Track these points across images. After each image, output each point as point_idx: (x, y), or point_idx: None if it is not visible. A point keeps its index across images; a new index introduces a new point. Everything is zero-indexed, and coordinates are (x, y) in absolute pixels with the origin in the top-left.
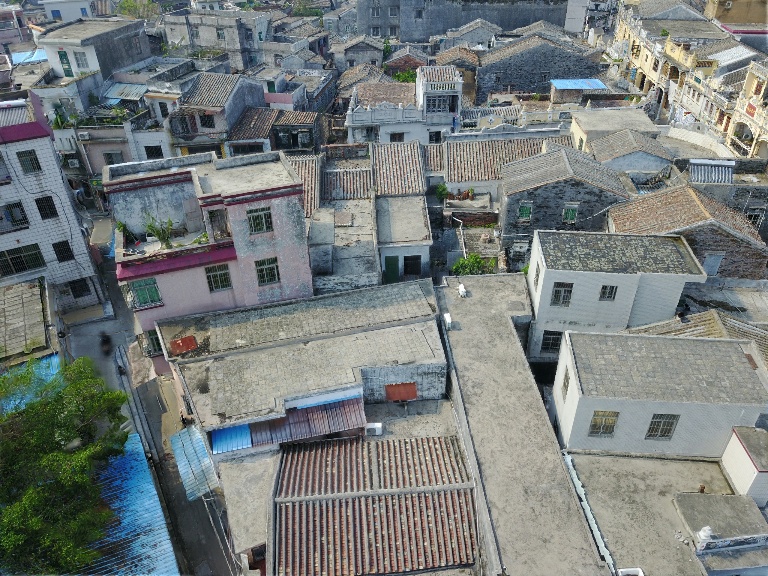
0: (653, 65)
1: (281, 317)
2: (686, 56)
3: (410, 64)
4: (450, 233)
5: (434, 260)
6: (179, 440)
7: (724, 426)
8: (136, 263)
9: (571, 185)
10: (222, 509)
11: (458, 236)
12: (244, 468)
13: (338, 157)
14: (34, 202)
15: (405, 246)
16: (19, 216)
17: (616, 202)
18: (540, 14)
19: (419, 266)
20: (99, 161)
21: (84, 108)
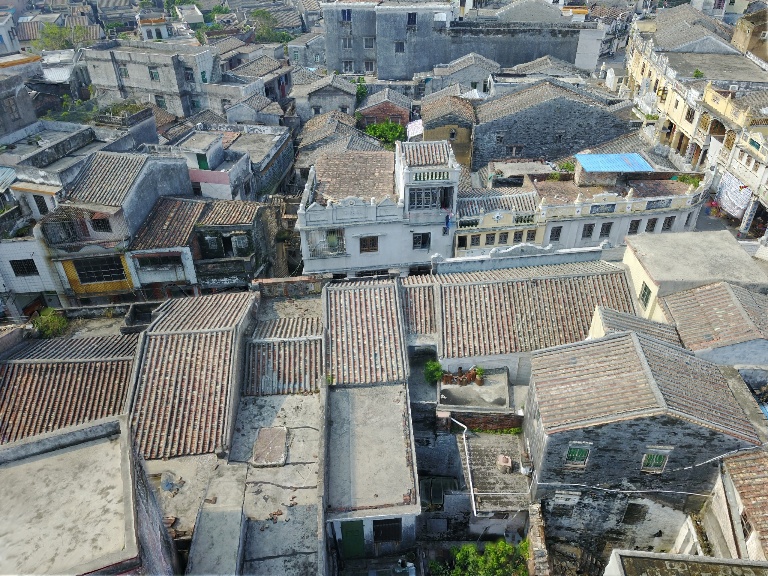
0: (686, 114)
1: None
2: (736, 110)
3: (389, 112)
4: (447, 439)
5: (423, 504)
6: None
7: None
8: None
9: (661, 423)
10: None
11: (460, 454)
12: None
13: (279, 296)
14: None
15: (373, 518)
16: None
17: (737, 449)
18: (546, 48)
19: (398, 530)
20: None
21: None
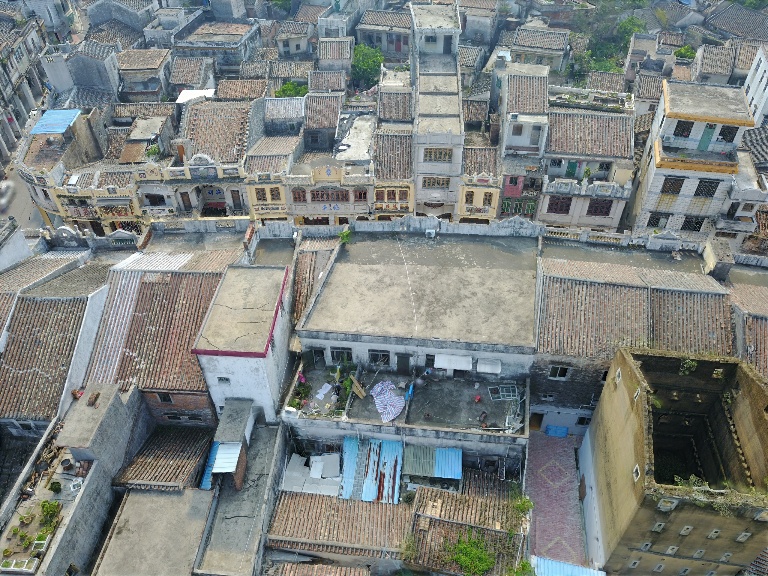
0: None
1: None
2: (174, 222)
3: None
4: None
5: None
6: None
7: None
8: None
9: None
10: None
11: None
12: None
13: None
14: None
15: None
16: None
17: None
18: None
19: None
20: None
21: None
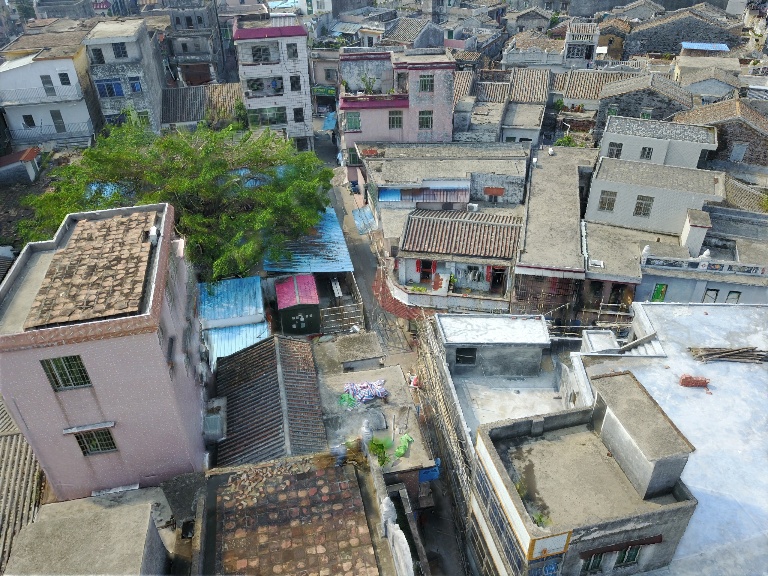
0: None
1: (429, 148)
2: None
3: None
4: (560, 135)
5: None
6: (357, 211)
7: (682, 208)
8: (351, 101)
9: (648, 94)
10: (377, 238)
11: (564, 135)
12: (394, 212)
13: (489, 79)
14: (289, 78)
15: (521, 128)
16: (280, 86)
17: (681, 110)
18: None
19: None
20: (321, 75)
21: (317, 36)
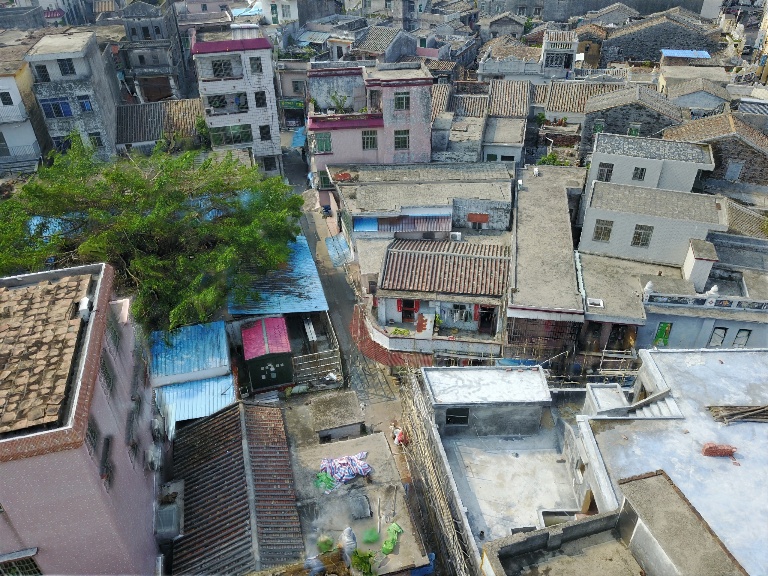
0: None
1: (406, 170)
2: None
3: None
4: (543, 150)
5: None
6: (331, 239)
7: (684, 238)
8: (321, 120)
9: (636, 108)
10: (353, 271)
11: (547, 151)
12: (371, 243)
13: (466, 91)
14: (254, 94)
15: (502, 146)
16: (243, 102)
17: (671, 125)
18: (678, 0)
19: None
20: (288, 87)
21: (284, 46)
